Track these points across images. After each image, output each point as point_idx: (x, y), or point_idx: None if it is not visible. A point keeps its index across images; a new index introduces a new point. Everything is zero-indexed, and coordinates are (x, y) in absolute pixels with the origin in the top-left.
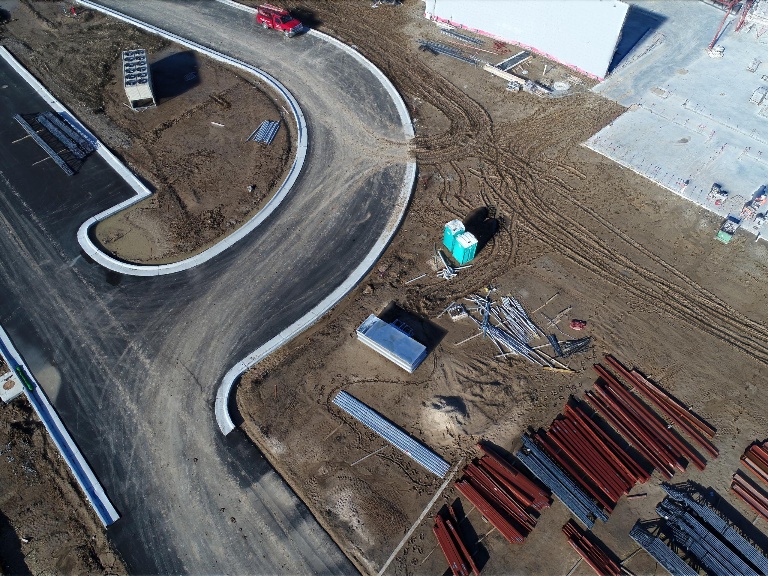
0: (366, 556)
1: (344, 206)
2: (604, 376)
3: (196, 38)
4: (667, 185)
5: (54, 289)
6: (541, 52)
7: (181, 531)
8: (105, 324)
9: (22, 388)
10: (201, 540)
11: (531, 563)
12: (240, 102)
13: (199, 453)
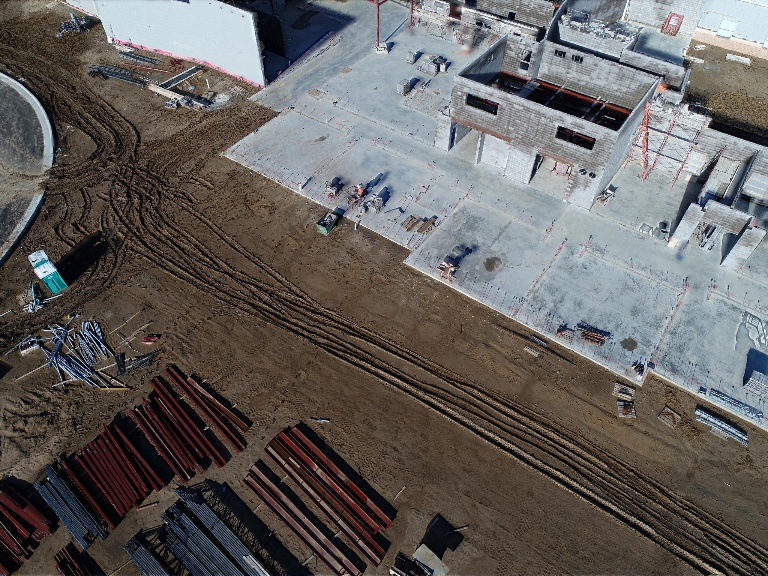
0: None
1: None
2: (157, 388)
3: None
4: (288, 185)
5: None
6: (213, 66)
7: None
8: None
9: None
10: None
11: None
12: None
13: None
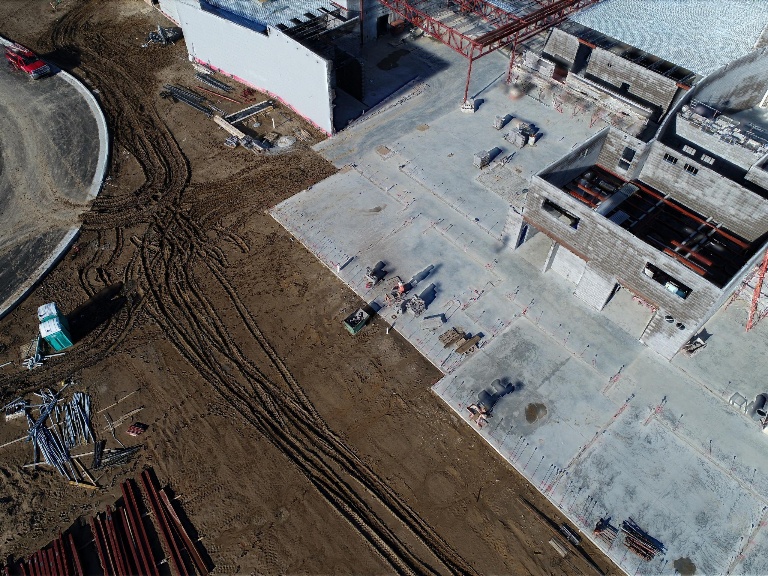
0: None
1: None
2: (126, 495)
3: None
4: (327, 262)
5: None
6: (285, 102)
7: None
8: None
9: None
10: None
11: None
12: None
13: None
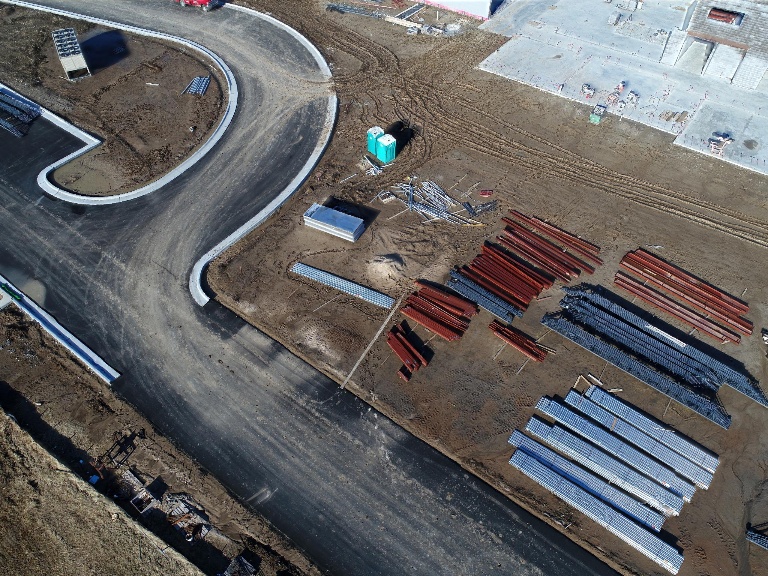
0: (335, 368)
1: (278, 133)
2: (510, 224)
3: (119, 19)
4: (547, 89)
5: (24, 224)
6: (433, 3)
7: (176, 376)
8: (78, 243)
9: (11, 298)
10: (195, 379)
11: (467, 352)
12: (170, 65)
13: (182, 322)
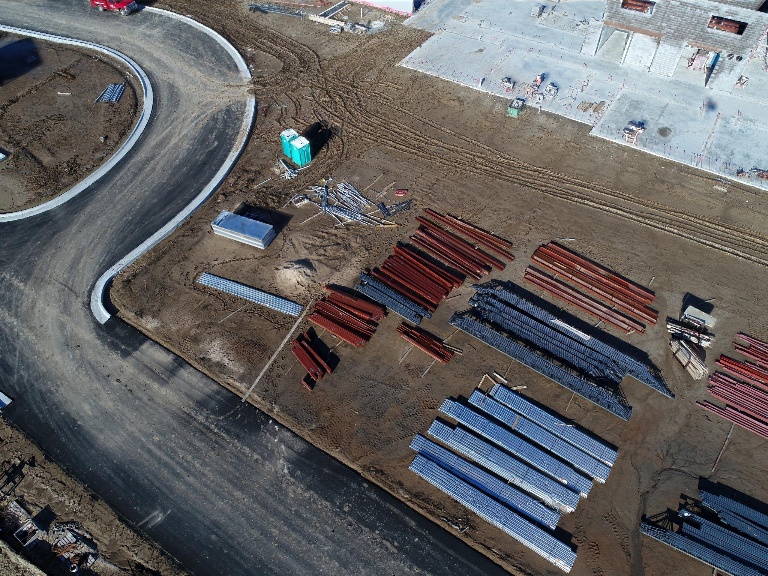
0: (238, 381)
1: (193, 140)
2: (424, 223)
3: (33, 27)
4: (468, 84)
5: None
6: (358, 0)
7: (72, 398)
8: None
9: None
10: (91, 401)
11: (373, 357)
12: (84, 73)
13: (80, 341)
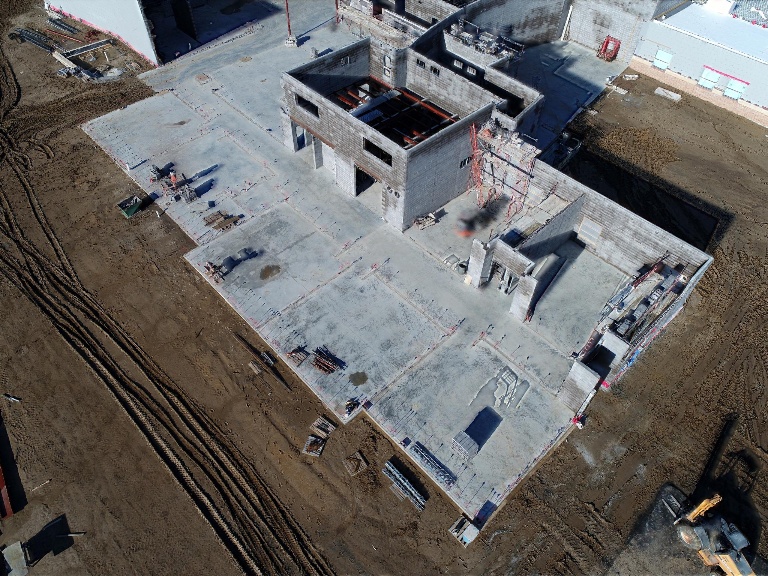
0: None
1: None
2: None
3: None
4: (121, 164)
5: None
6: (124, 40)
7: None
8: None
9: None
10: None
11: None
12: None
13: None
